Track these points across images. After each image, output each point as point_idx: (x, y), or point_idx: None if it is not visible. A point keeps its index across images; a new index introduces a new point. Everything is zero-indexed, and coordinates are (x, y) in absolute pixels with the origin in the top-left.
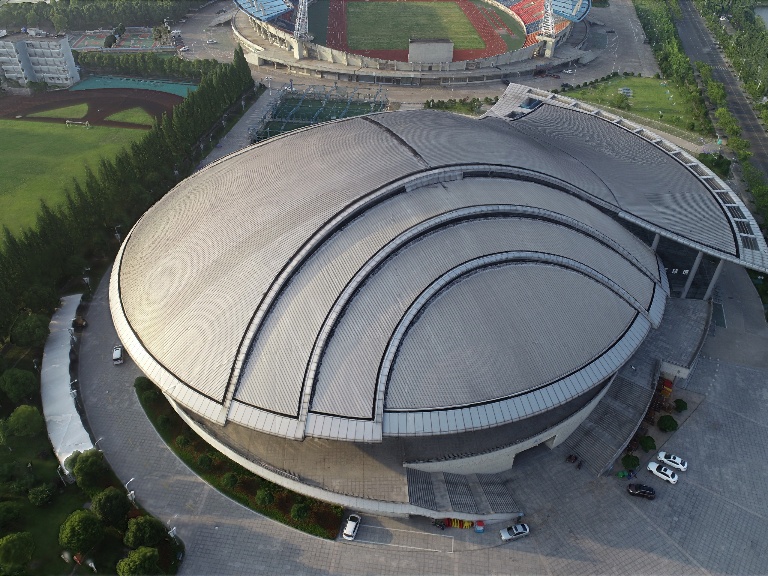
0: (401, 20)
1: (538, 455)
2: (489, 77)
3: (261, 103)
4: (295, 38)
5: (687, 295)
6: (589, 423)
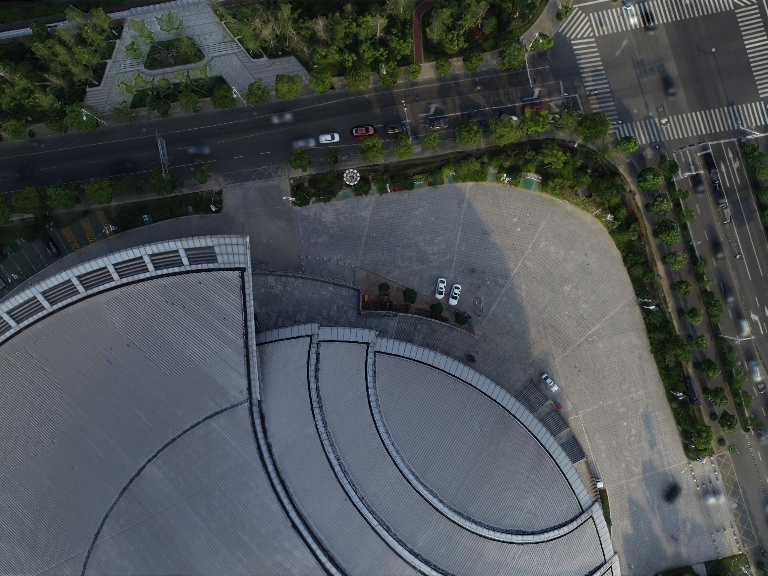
0: None
1: None
2: None
3: None
4: None
5: None
6: None
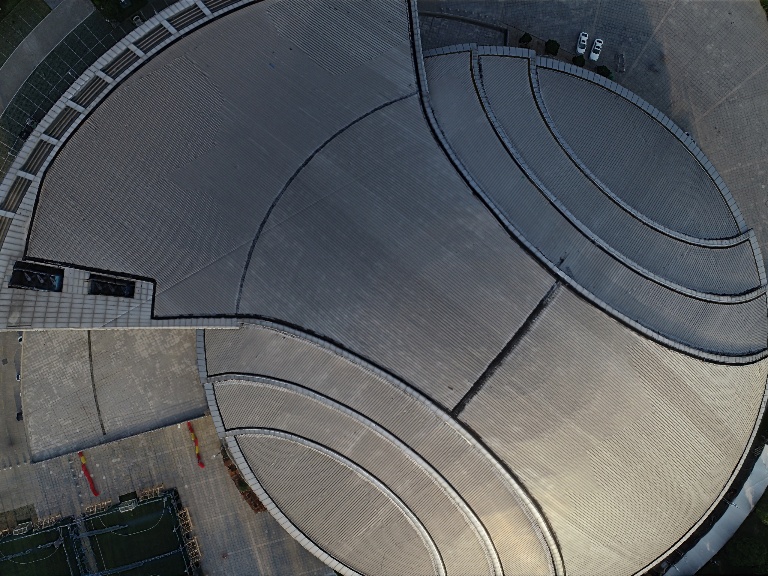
0: None
1: None
2: None
3: None
4: None
5: None
6: None
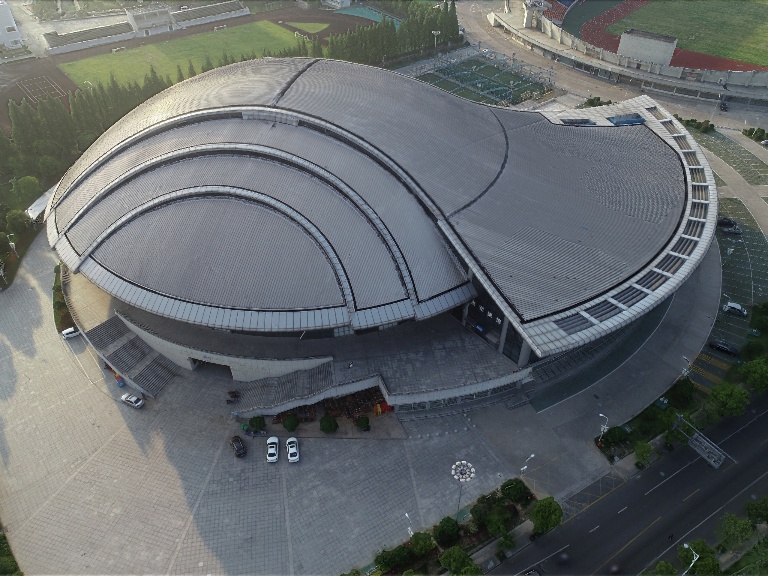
0: (710, 15)
1: (221, 377)
2: (705, 94)
3: (446, 57)
4: (527, 5)
5: (504, 351)
6: (274, 381)
